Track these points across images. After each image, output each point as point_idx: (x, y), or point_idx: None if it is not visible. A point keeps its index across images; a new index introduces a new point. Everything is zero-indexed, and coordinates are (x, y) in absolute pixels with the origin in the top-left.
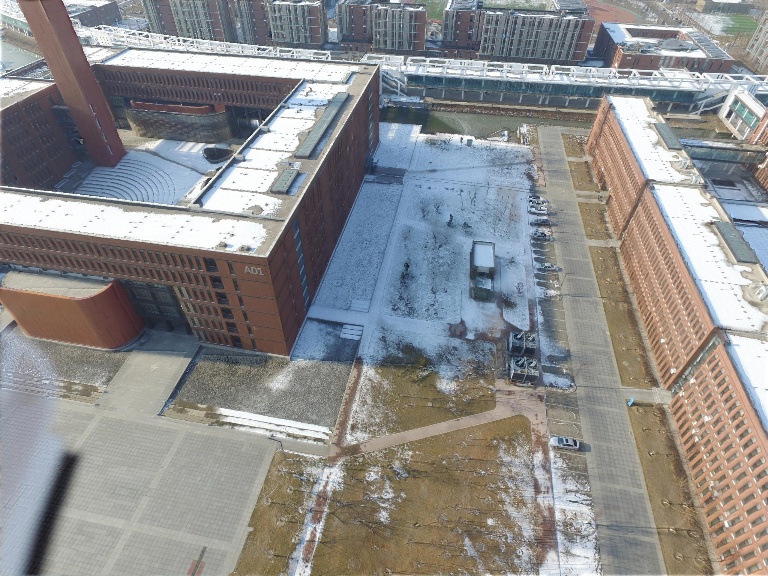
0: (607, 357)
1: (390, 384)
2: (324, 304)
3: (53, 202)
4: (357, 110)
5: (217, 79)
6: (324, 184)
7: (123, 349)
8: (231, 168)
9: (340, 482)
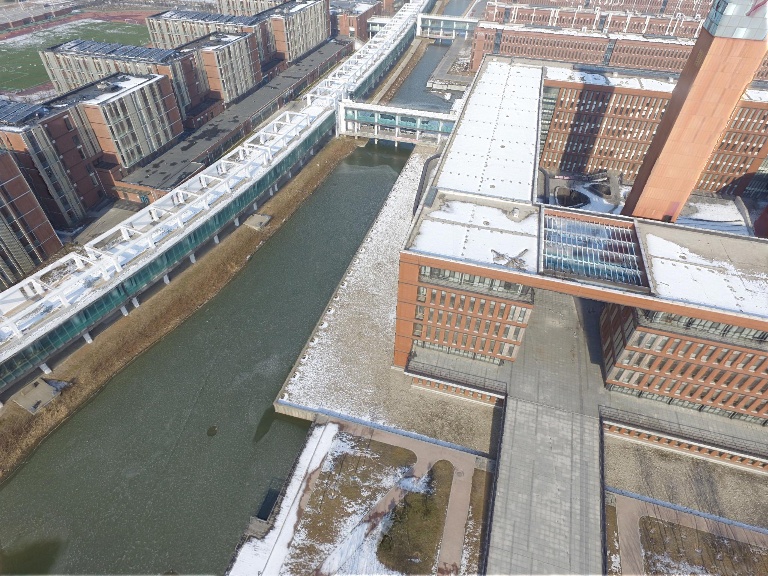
0: None
1: None
2: None
3: None
4: None
5: None
6: None
7: None
8: None
9: None
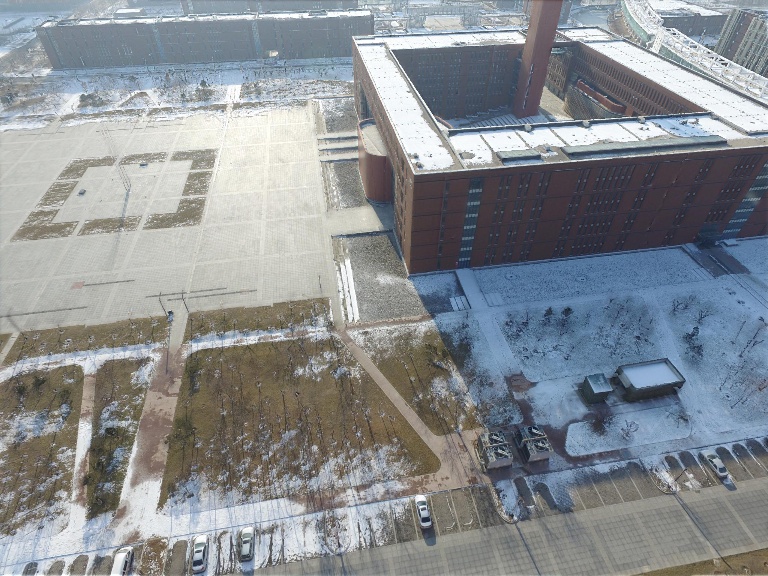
0: (594, 567)
1: (419, 344)
2: (478, 276)
3: (409, 94)
4: (710, 159)
5: (643, 83)
6: (561, 185)
7: (371, 202)
8: (511, 130)
9: (317, 339)
